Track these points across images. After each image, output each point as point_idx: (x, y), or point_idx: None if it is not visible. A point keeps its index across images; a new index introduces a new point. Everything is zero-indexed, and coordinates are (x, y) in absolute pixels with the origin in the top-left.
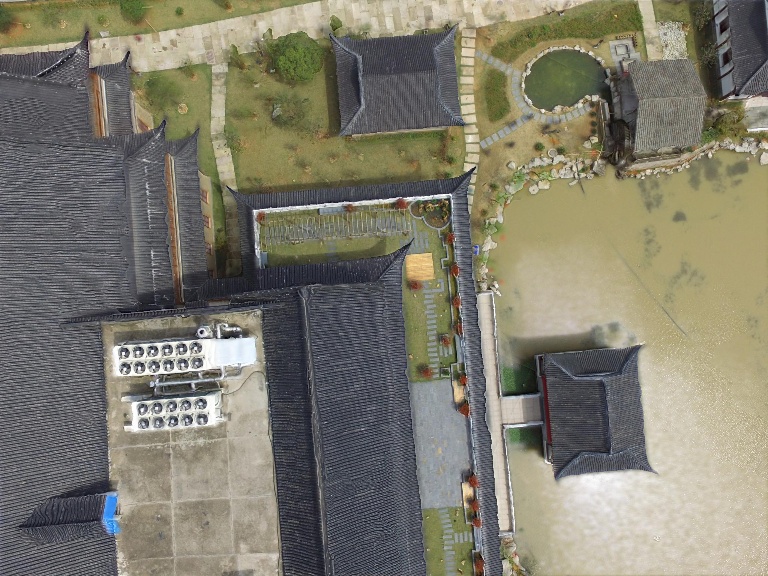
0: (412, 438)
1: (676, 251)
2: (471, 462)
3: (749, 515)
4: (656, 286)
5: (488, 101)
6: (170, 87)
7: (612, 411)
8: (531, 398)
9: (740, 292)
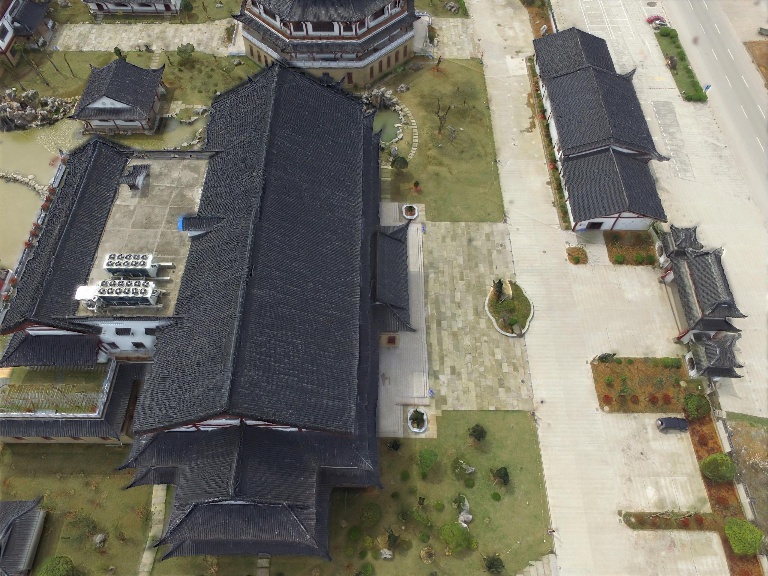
0: None
1: None
2: (27, 255)
3: None
4: None
5: None
6: (186, 573)
7: None
8: None
9: None
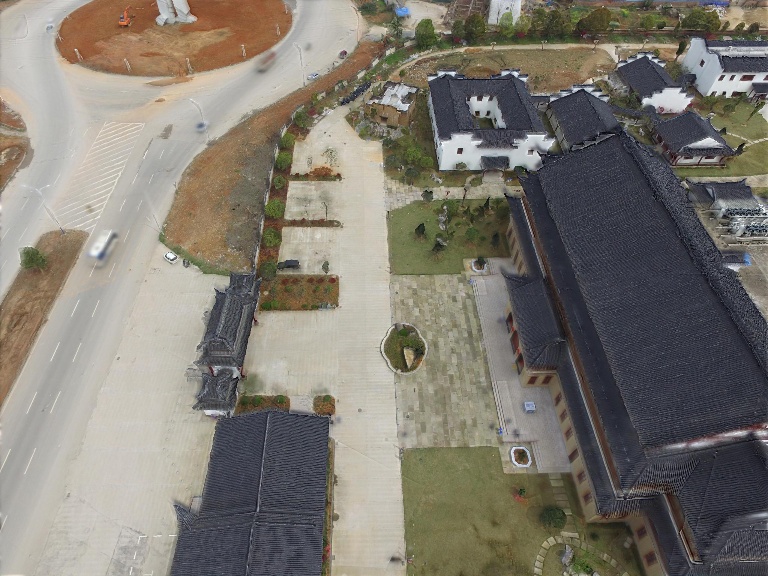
0: None
1: None
2: None
3: None
4: None
5: None
6: None
7: None
8: None
9: None
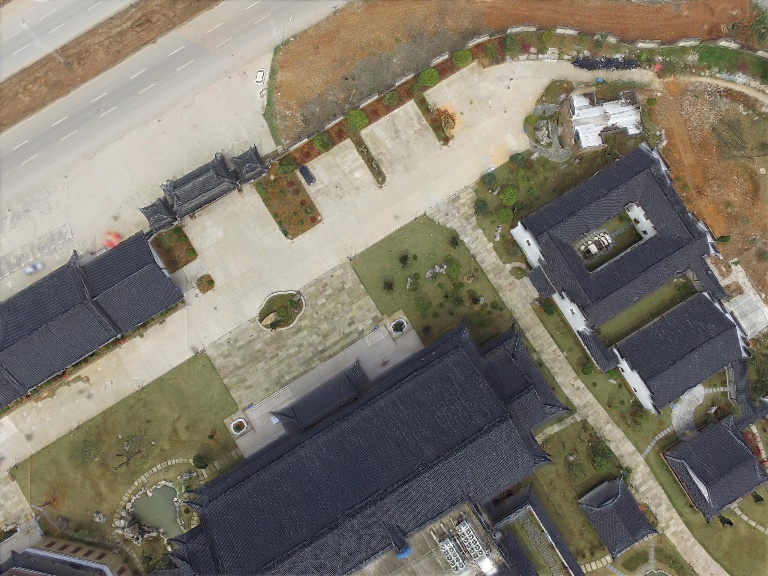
0: None
1: None
2: None
3: None
4: None
5: (631, 558)
6: None
7: None
8: None
9: None
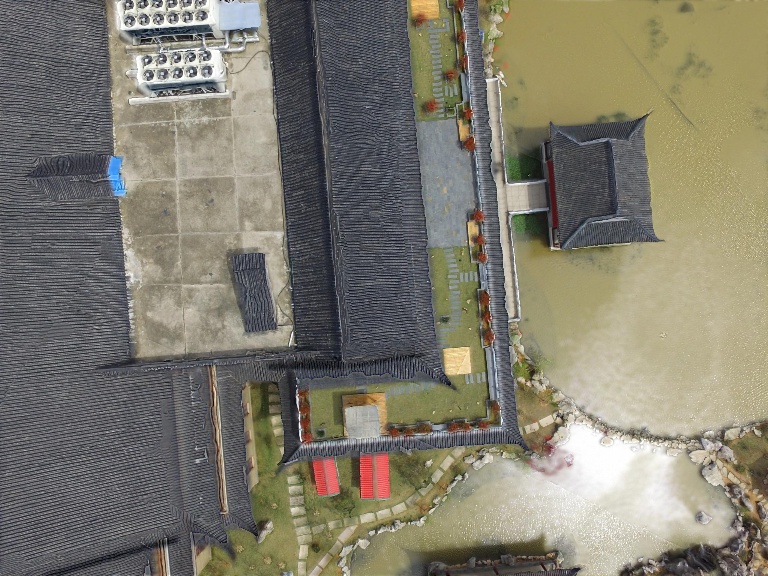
0: (417, 157)
1: (684, 43)
2: (476, 201)
3: (757, 308)
4: (664, 77)
5: None
6: None
7: (619, 175)
8: (537, 185)
9: (749, 83)
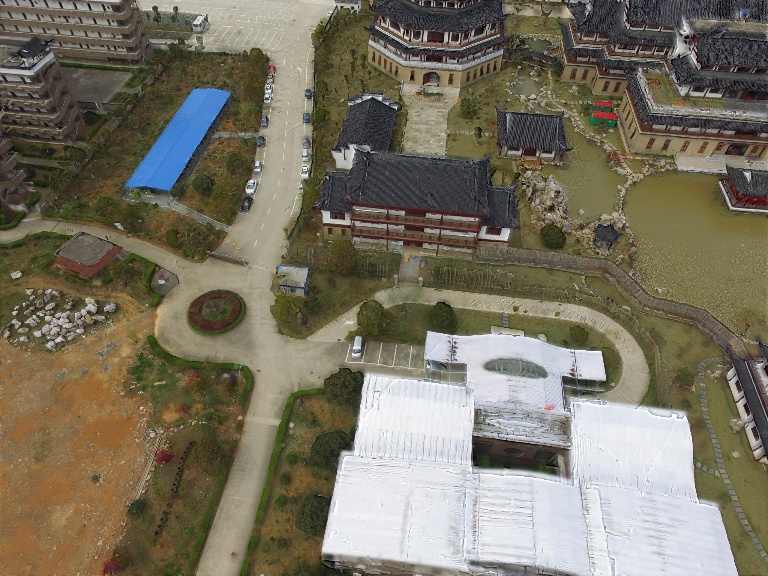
0: (766, 91)
1: None
2: None
3: None
4: None
5: None
6: None
7: None
8: None
9: None
